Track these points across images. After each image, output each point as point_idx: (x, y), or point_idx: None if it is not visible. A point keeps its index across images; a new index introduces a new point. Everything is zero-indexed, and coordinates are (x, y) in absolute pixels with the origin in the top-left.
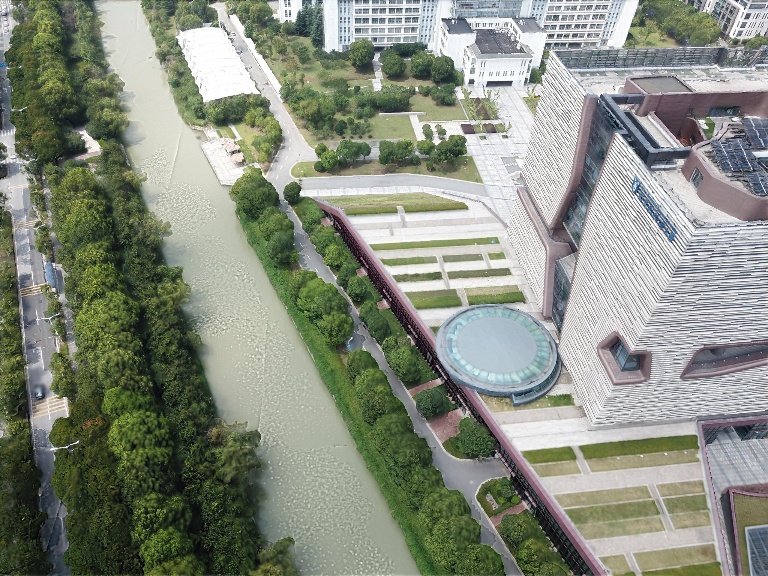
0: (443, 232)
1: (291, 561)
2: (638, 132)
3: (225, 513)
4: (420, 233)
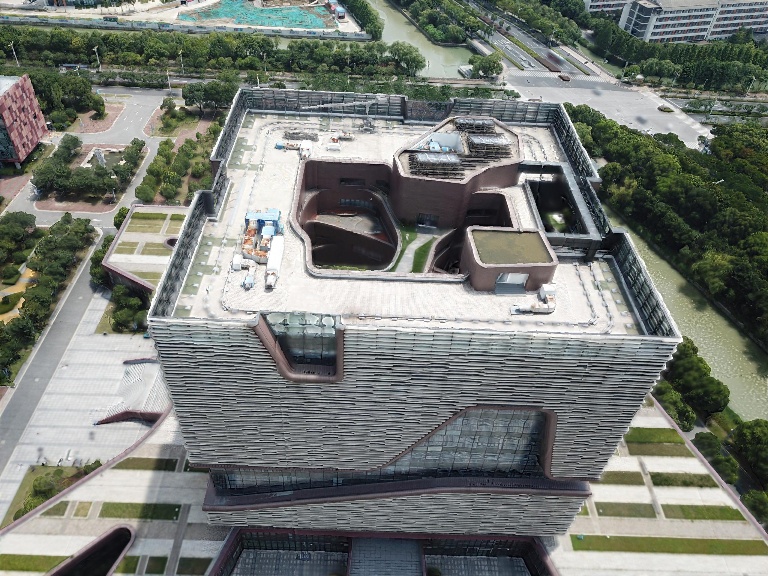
0: (663, 573)
1: (708, 276)
2: (572, 184)
3: (767, 293)
4: (701, 575)
